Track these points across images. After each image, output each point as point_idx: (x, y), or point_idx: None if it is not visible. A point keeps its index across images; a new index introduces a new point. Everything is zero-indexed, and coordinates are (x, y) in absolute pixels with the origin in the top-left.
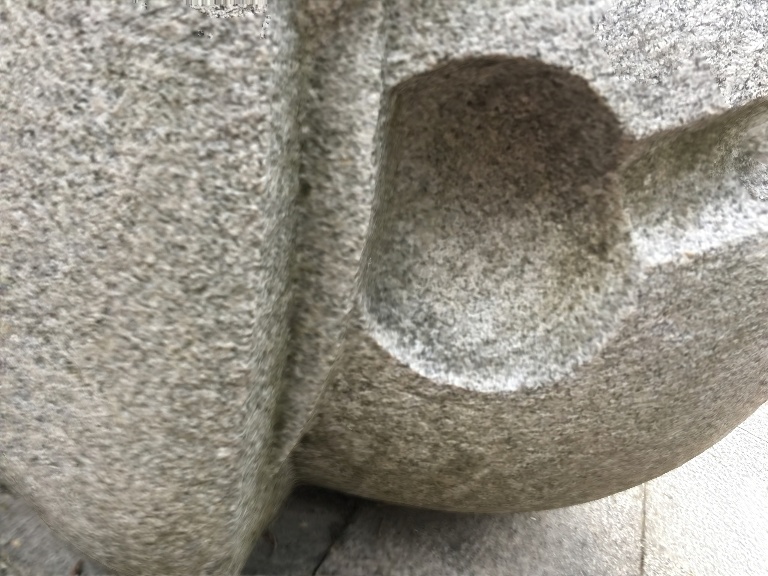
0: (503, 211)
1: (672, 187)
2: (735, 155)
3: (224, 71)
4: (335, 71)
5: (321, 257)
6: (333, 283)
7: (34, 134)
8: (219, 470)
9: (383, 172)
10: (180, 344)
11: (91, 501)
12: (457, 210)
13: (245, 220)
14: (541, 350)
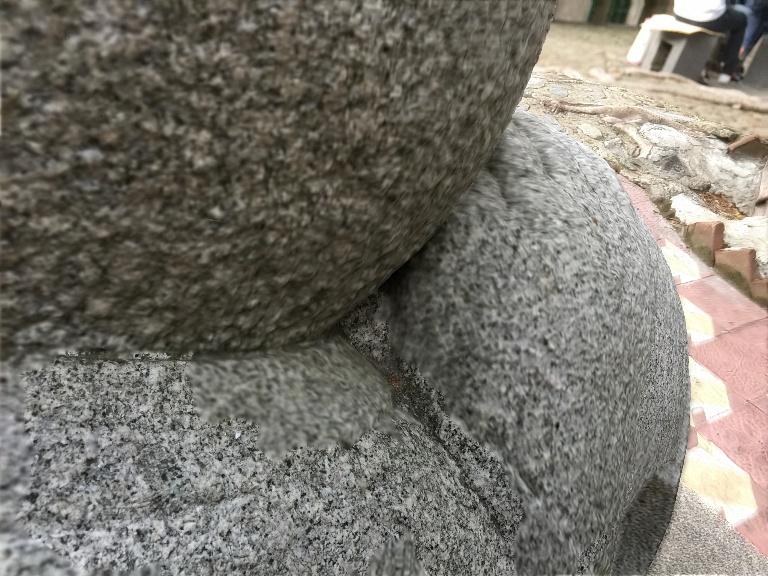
0: None
1: None
2: None
3: None
4: None
5: None
6: None
7: None
8: None
9: None
10: None
11: None
12: None
13: None
14: (629, 548)
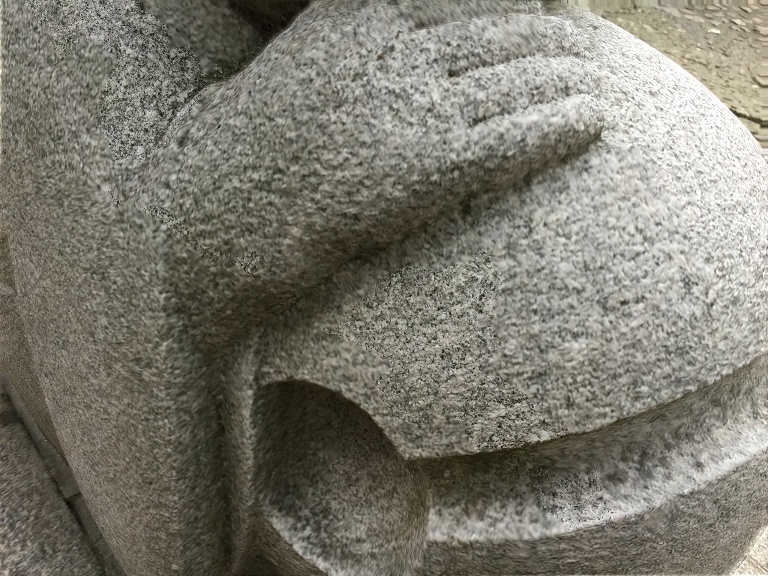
0: (382, 450)
1: (469, 481)
2: (530, 467)
3: (148, 381)
4: (232, 369)
5: (233, 468)
6: (240, 485)
7: (82, 378)
8: (174, 575)
9: (274, 424)
10: (143, 505)
11: (124, 562)
12: (353, 441)
13: (165, 455)
14: (384, 562)
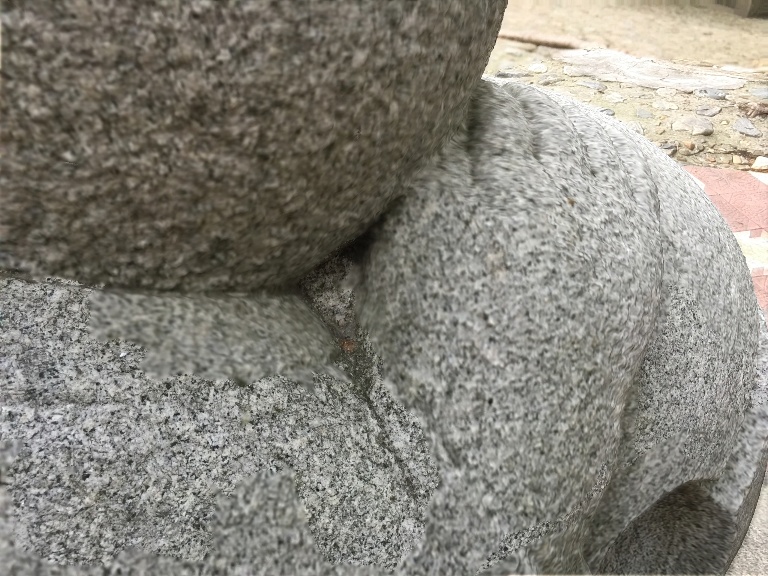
0: None
1: None
2: None
3: None
4: None
5: None
6: None
7: None
8: None
9: None
10: None
11: None
12: None
13: None
14: (683, 575)
